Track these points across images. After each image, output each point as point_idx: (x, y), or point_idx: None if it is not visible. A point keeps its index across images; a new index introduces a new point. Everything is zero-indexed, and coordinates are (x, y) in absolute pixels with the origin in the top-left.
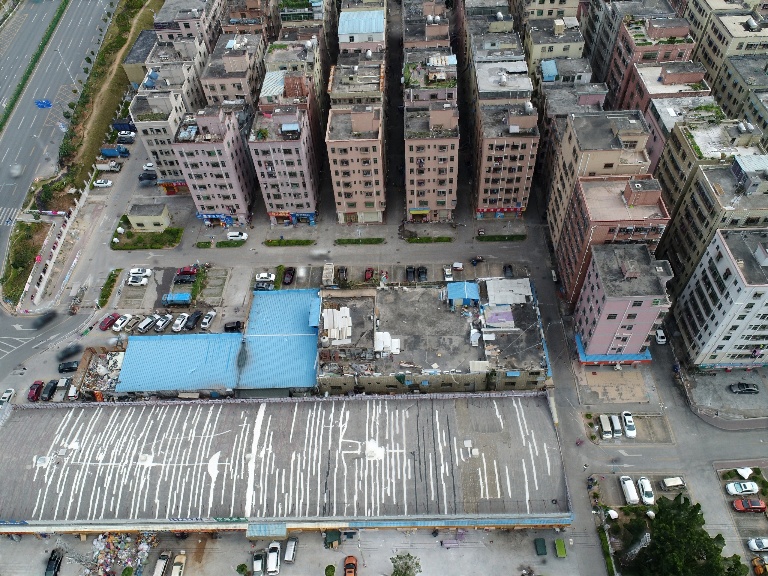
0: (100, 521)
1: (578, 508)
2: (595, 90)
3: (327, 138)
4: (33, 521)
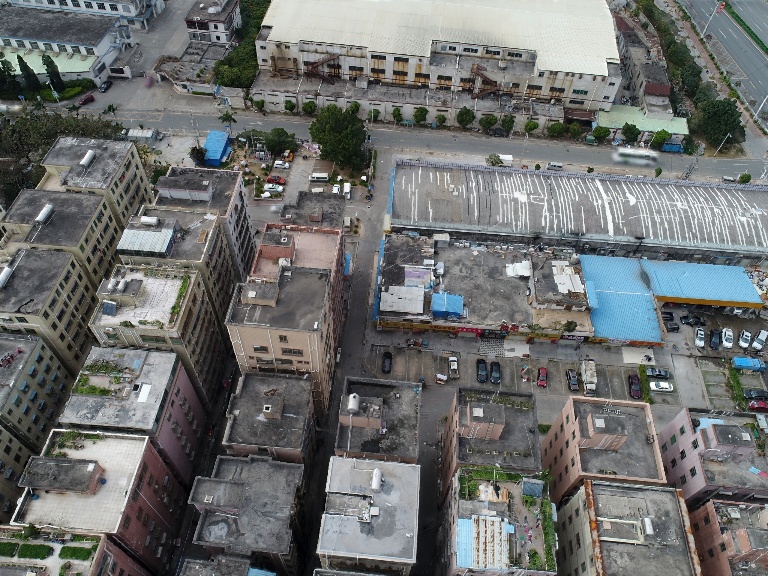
0: (691, 182)
1: (382, 188)
2: (214, 489)
3: (648, 409)
4: (736, 185)
